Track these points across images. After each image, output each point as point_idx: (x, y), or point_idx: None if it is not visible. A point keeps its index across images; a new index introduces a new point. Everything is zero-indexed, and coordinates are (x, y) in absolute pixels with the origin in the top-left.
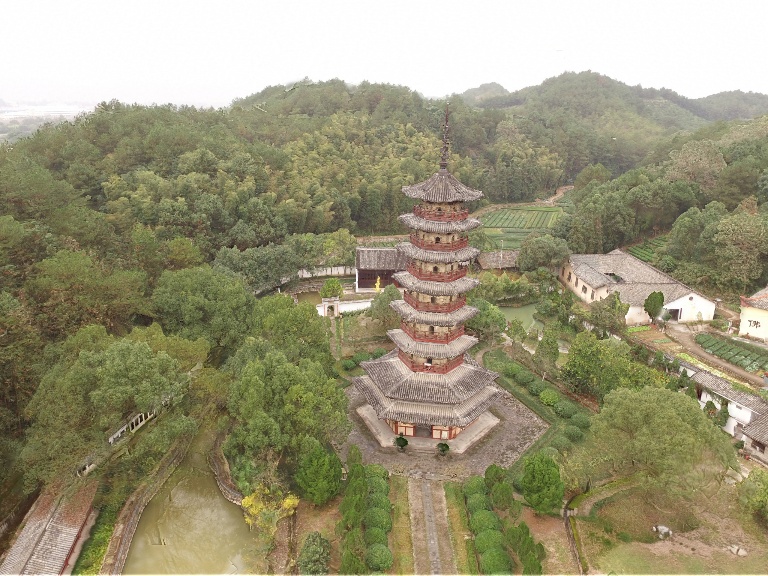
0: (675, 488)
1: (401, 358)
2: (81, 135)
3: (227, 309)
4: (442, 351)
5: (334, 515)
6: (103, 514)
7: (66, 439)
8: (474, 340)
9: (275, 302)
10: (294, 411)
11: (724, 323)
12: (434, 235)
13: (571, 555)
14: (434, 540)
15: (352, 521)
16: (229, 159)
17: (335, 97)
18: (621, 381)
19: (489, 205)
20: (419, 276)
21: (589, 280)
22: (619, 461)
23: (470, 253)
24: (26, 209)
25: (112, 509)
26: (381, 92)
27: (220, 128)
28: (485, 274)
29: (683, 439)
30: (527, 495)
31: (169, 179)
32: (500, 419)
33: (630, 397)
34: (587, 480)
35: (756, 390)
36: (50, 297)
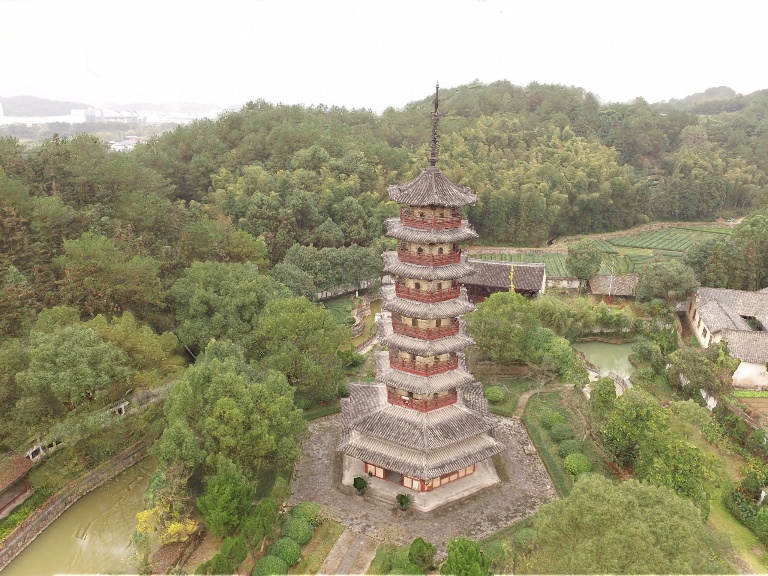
0: None
1: (386, 385)
2: (214, 130)
3: (231, 306)
4: (418, 385)
5: None
6: (34, 495)
7: None
8: (468, 377)
9: (285, 305)
10: (215, 426)
11: None
12: (416, 245)
13: None
14: None
15: (213, 568)
16: (342, 157)
17: (495, 99)
18: None
19: (653, 222)
20: (396, 292)
21: (710, 322)
22: None
23: (460, 270)
24: (96, 193)
25: (44, 492)
26: (547, 93)
27: (360, 128)
28: (577, 300)
29: (638, 571)
30: None
31: (273, 174)
32: (502, 479)
33: (589, 491)
34: None
35: None
36: (65, 276)
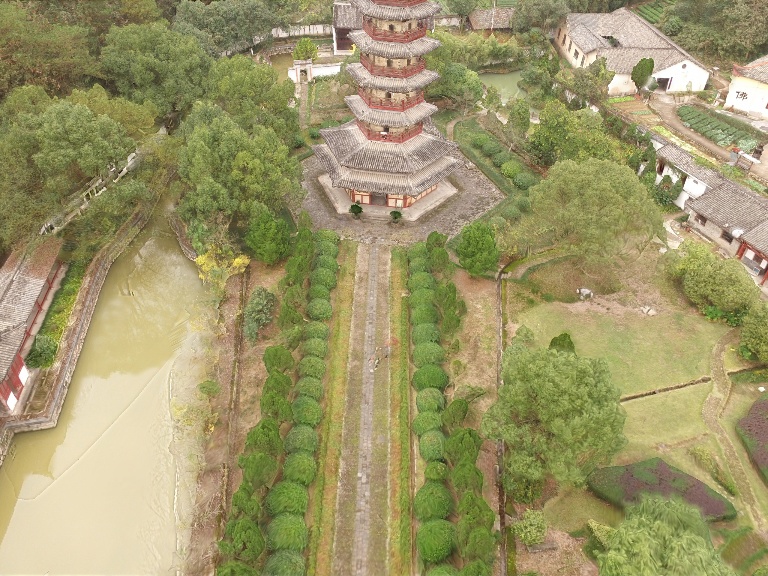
0: (593, 255)
1: (359, 126)
2: None
3: (180, 71)
4: (397, 119)
5: (284, 273)
6: (72, 268)
7: (16, 200)
8: (433, 108)
9: (231, 64)
10: (241, 177)
11: (713, 94)
12: None
13: (496, 311)
14: (373, 296)
15: (293, 278)
16: None
17: None
18: (579, 153)
19: None
20: (373, 35)
21: (582, 44)
22: (562, 231)
23: (429, 9)
24: None
25: (80, 264)
26: None
27: None
28: (471, 35)
29: (611, 210)
30: (462, 259)
31: None
32: (458, 189)
33: (570, 169)
34: (527, 247)
35: (720, 165)
36: None
